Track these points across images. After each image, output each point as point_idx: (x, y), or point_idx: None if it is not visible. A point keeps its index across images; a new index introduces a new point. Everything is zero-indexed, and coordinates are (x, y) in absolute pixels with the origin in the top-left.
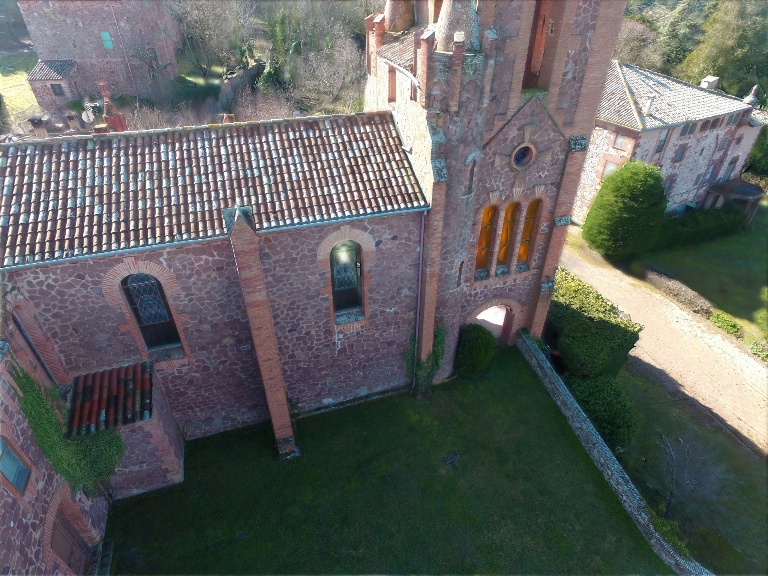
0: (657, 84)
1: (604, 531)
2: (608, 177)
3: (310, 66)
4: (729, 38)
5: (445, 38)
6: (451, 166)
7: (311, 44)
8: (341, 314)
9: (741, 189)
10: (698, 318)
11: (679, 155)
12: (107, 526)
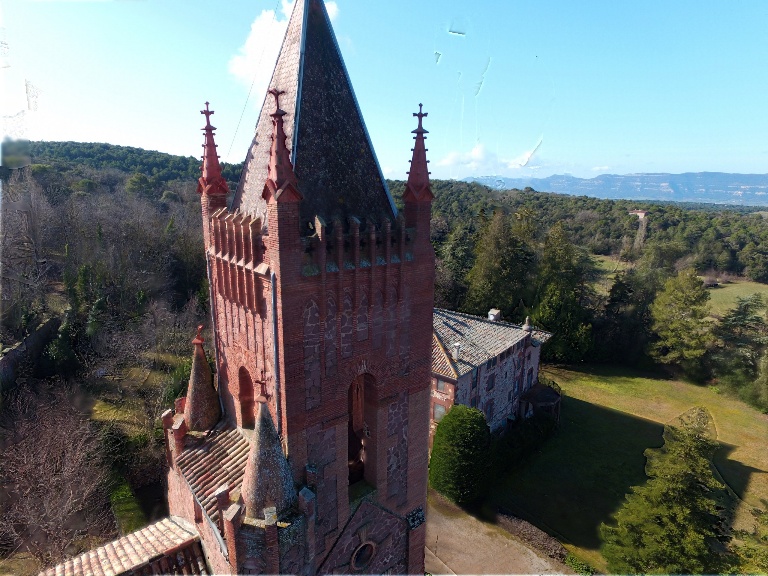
0: (457, 324)
1: None
2: (440, 423)
3: (114, 342)
4: (494, 262)
5: (254, 504)
6: None
7: (120, 295)
8: None
9: (543, 395)
10: (556, 564)
11: (490, 383)
12: None
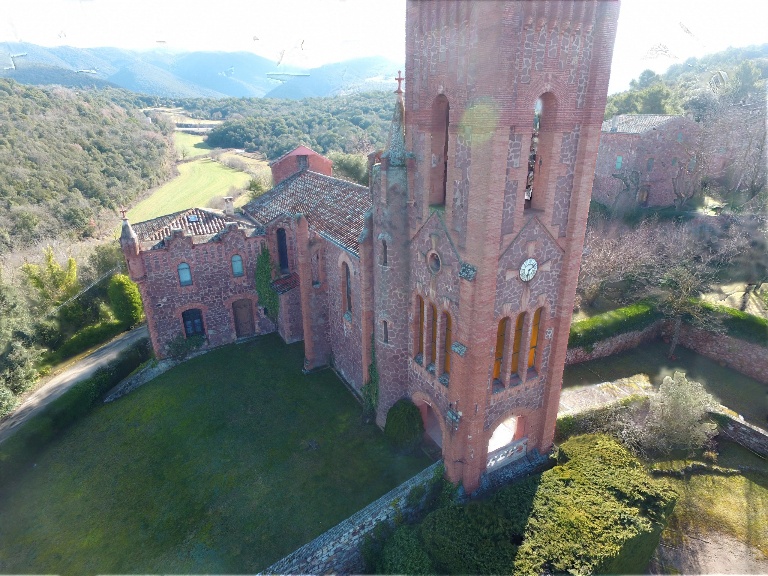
0: None
1: (260, 560)
2: None
3: None
4: None
5: None
6: (373, 237)
7: None
8: (349, 313)
9: None
10: None
11: None
12: (266, 334)
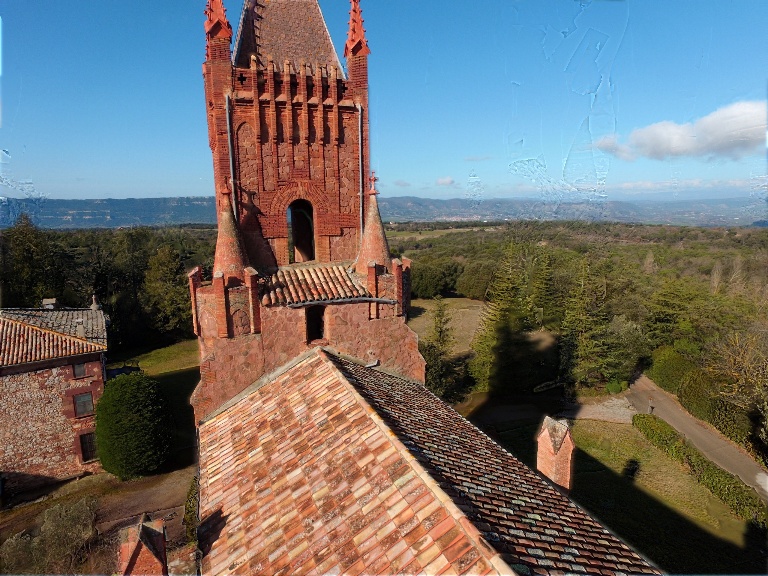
0: None
1: None
2: (106, 404)
3: None
4: None
5: None
6: None
7: None
8: None
9: None
10: None
11: None
12: None
